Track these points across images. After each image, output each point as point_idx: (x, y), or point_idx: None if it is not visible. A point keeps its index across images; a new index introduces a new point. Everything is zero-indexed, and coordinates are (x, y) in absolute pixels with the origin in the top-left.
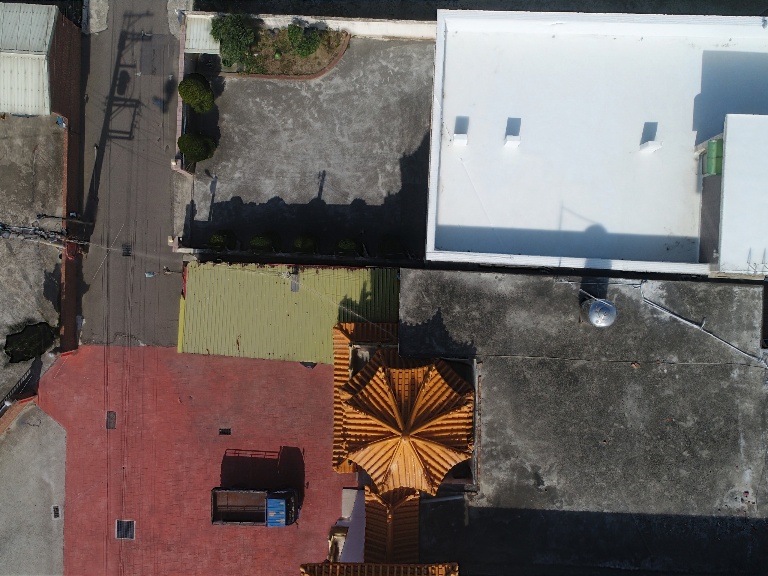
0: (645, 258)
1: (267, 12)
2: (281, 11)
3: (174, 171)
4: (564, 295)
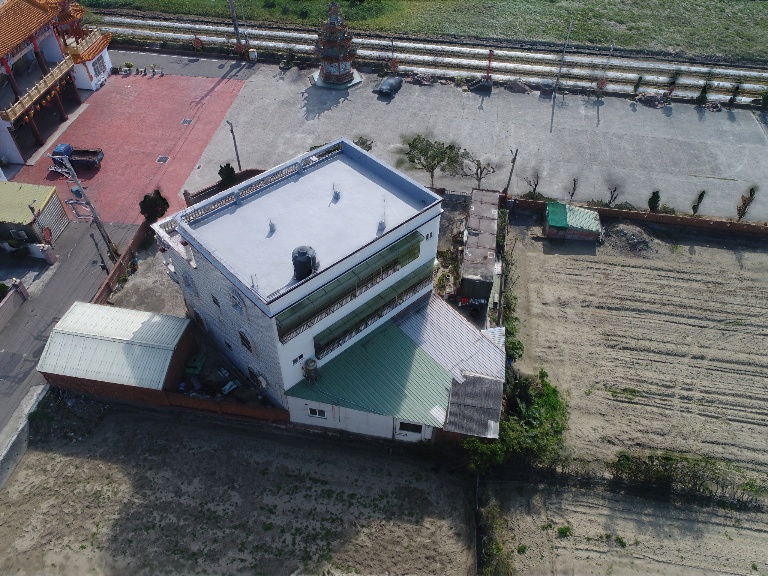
0: None
1: None
2: None
3: (36, 298)
4: None
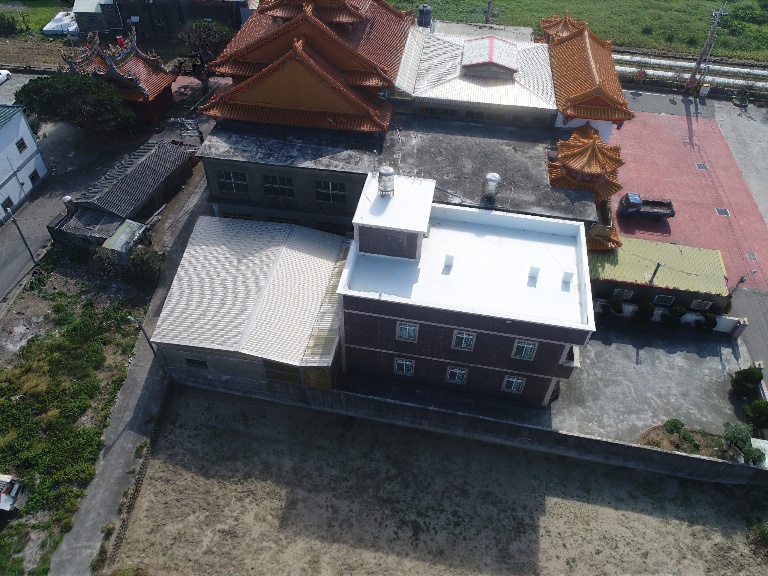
0: (452, 222)
1: (715, 501)
2: (702, 500)
3: None
4: (504, 203)
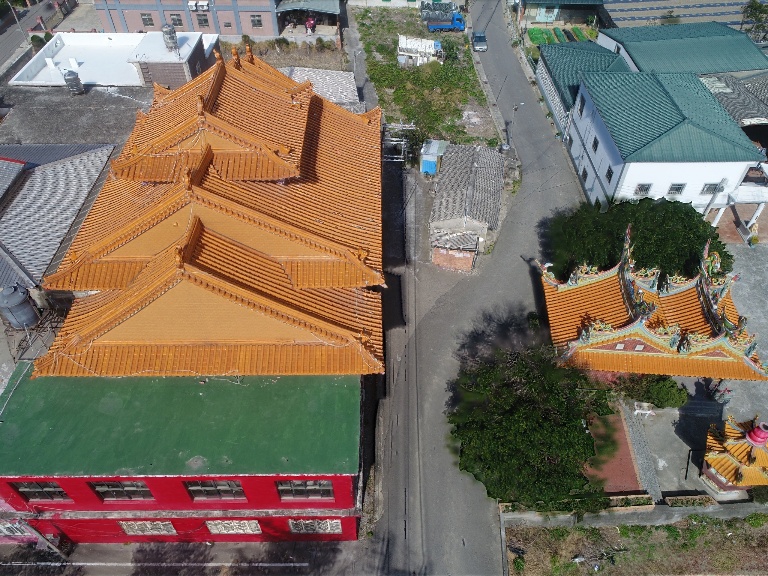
0: None
1: None
2: None
3: None
4: (69, 91)
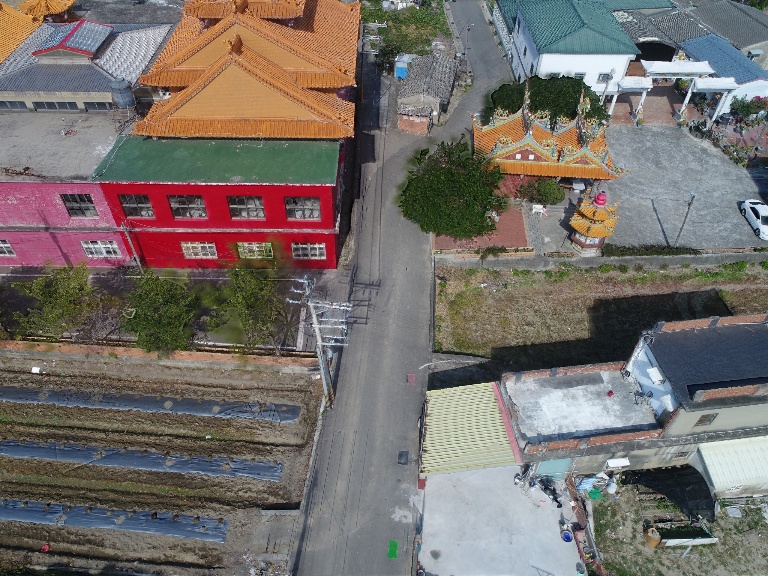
0: None
1: None
2: None
3: None
4: (130, 2)
